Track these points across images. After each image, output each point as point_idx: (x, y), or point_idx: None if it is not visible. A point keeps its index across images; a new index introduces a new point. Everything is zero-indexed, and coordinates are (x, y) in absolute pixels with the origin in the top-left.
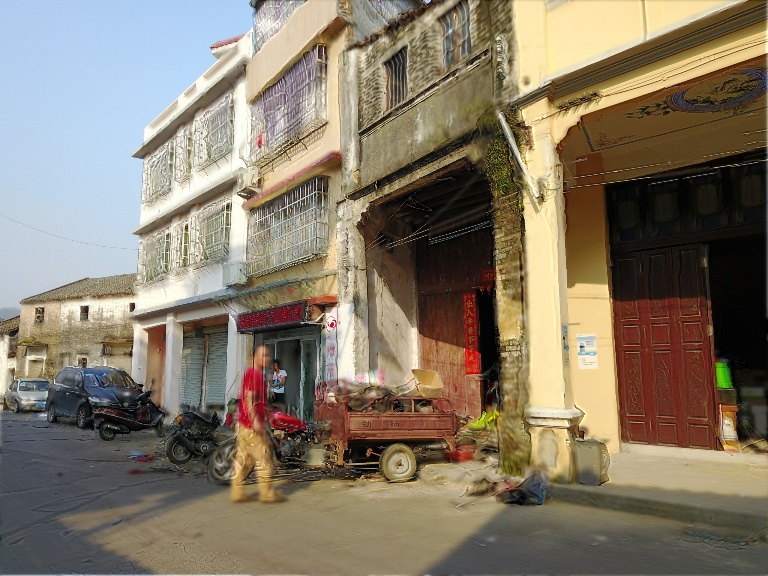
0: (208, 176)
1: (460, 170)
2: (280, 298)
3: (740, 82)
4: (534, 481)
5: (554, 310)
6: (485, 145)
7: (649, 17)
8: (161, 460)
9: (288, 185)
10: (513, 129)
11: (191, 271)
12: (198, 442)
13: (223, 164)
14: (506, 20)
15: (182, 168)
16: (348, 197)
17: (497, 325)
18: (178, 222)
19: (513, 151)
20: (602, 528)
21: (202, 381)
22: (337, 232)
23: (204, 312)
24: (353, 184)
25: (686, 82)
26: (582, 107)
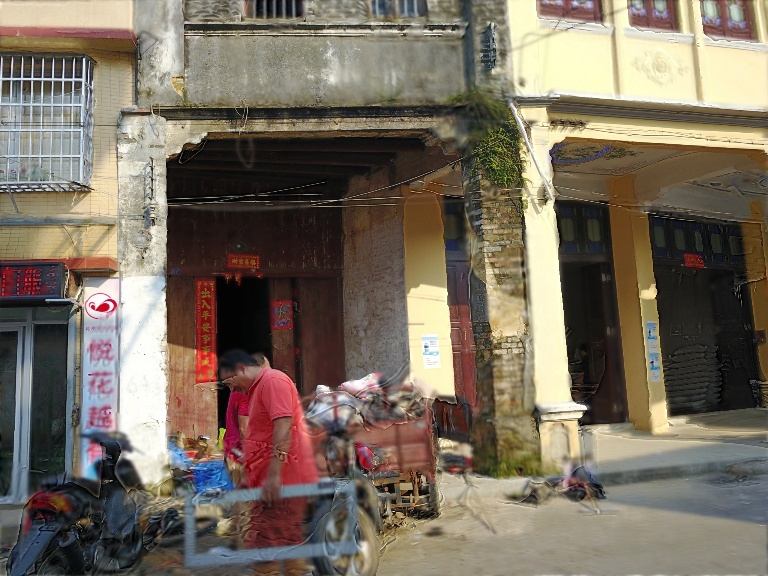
0: None
1: (409, 140)
2: None
3: (592, 150)
4: (588, 473)
5: (560, 309)
6: (484, 128)
7: (623, 81)
8: None
9: None
10: (525, 125)
11: None
12: (85, 547)
13: None
14: (497, 11)
15: None
16: (156, 111)
17: (488, 321)
18: None
19: (529, 147)
20: (695, 494)
21: None
22: (121, 158)
23: None
24: (174, 95)
25: (639, 143)
26: (568, 129)
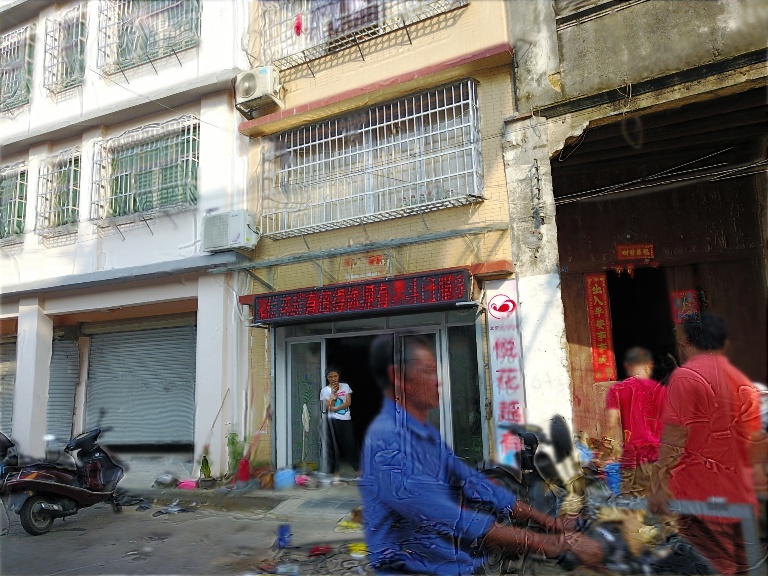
0: (129, 84)
1: None
2: (415, 263)
3: None
4: None
5: None
6: None
7: None
8: (352, 575)
9: (377, 93)
10: None
11: (111, 227)
12: (516, 531)
13: (166, 67)
14: None
15: (55, 71)
16: (536, 113)
17: None
18: (48, 154)
19: None
20: None
21: (74, 409)
22: (508, 165)
23: (130, 295)
24: (552, 93)
25: None
26: None
